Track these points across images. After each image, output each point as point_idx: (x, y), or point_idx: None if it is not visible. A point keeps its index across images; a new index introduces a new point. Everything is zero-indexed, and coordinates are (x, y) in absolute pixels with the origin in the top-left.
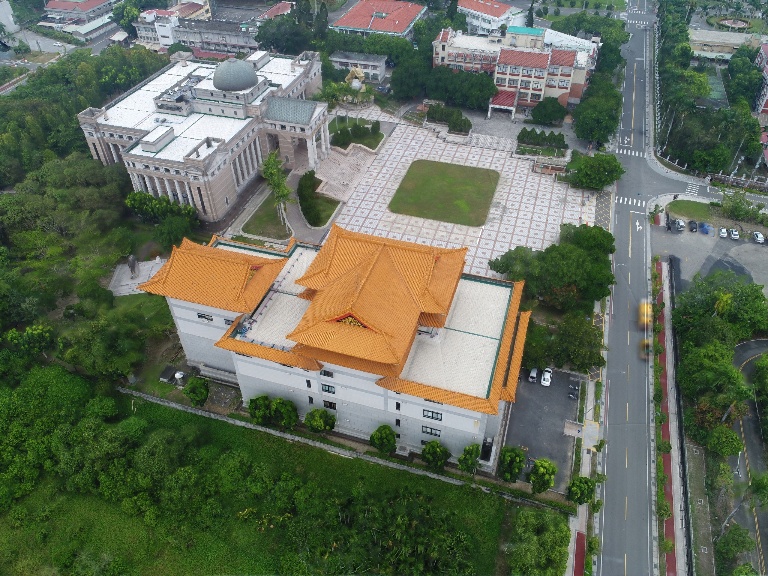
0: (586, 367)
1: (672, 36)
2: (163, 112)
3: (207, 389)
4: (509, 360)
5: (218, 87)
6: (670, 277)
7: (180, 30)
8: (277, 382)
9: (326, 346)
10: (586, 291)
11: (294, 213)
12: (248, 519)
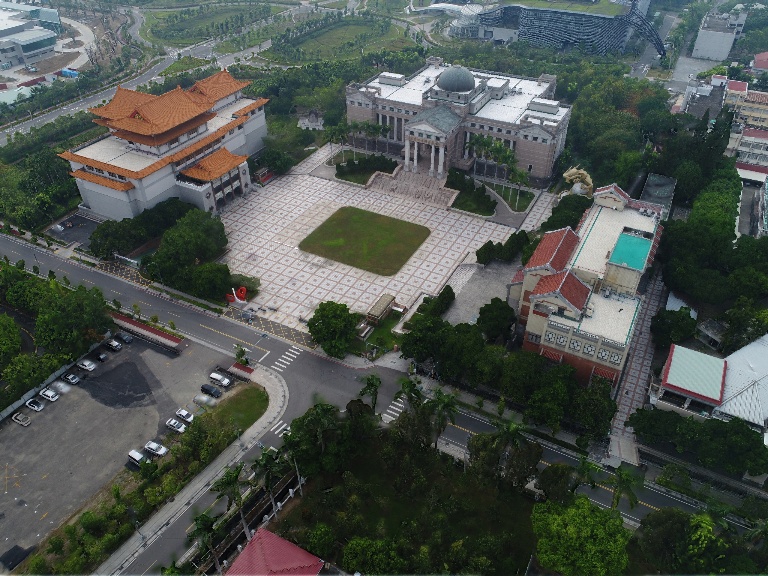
0: None
1: (767, 528)
2: None
3: None
4: None
5: None
6: None
7: None
8: None
9: None
10: None
11: None
12: None
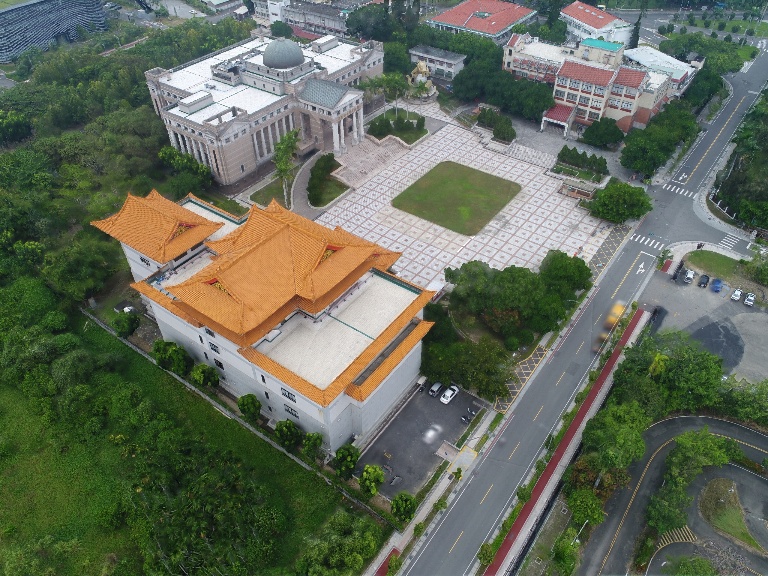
0: (485, 394)
1: None
2: (217, 80)
3: (133, 325)
4: (381, 363)
5: (264, 63)
6: None
7: (288, 9)
8: (181, 332)
9: (194, 304)
10: (531, 320)
11: (302, 190)
12: None
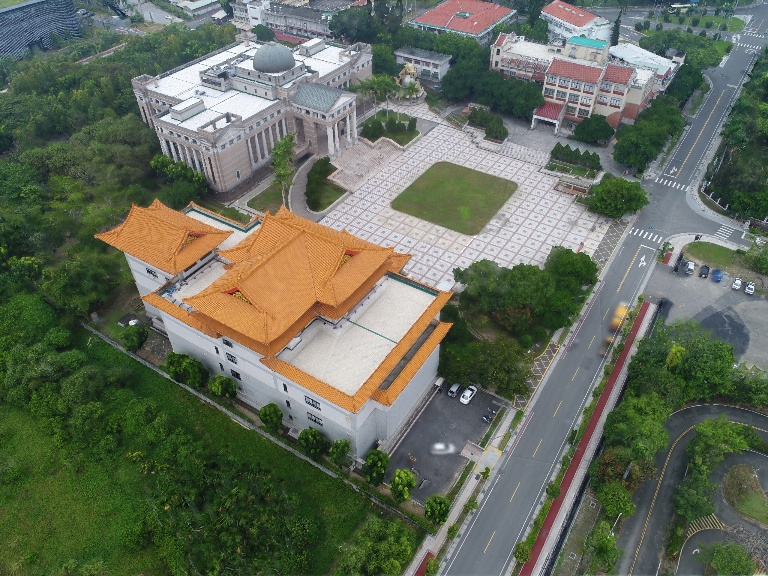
0: (505, 392)
1: (763, 64)
2: (206, 86)
3: (142, 338)
4: (404, 366)
5: (255, 67)
6: (653, 320)
7: (269, 13)
8: (195, 344)
9: (214, 315)
10: (543, 317)
11: (300, 195)
12: (136, 461)
